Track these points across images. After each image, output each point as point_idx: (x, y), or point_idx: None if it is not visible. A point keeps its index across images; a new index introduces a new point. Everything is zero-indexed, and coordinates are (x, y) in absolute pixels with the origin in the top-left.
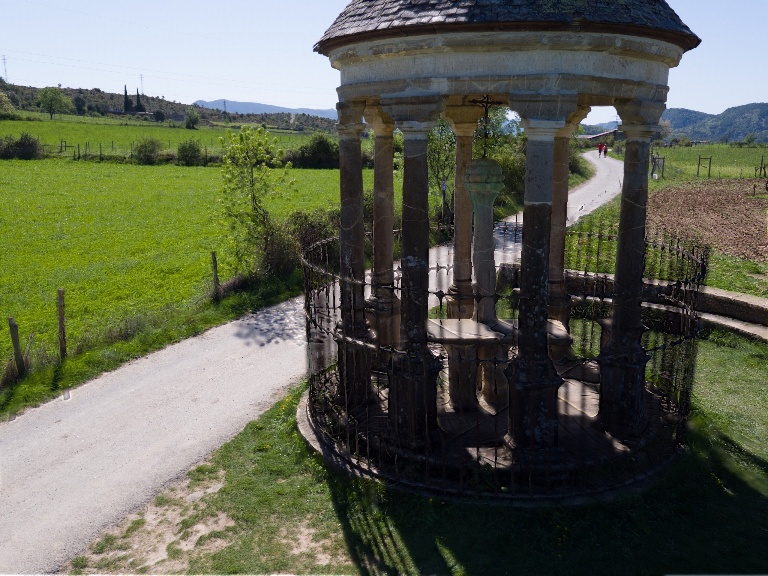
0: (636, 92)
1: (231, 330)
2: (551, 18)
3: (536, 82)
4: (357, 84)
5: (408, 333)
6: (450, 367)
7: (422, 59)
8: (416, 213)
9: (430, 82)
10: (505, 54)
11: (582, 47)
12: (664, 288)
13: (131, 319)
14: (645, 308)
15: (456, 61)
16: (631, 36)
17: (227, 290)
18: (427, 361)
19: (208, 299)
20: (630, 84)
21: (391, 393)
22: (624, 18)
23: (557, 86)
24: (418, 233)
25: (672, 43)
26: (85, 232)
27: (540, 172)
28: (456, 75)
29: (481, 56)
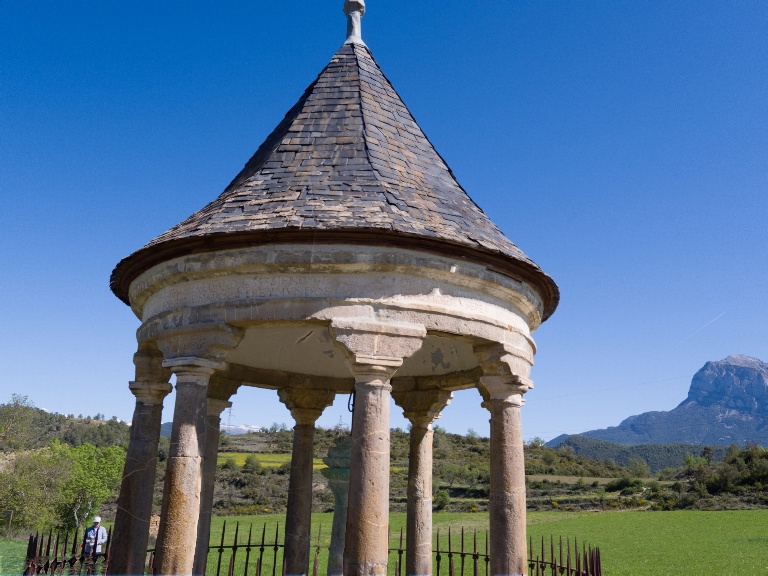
0: None
1: None
2: None
3: None
4: None
5: None
6: None
7: None
8: None
9: None
10: None
11: None
12: None
13: None
14: None
15: None
16: None
17: None
18: None
19: None
20: None
21: None
22: None
23: None
24: None
25: None
26: None
27: None
28: None
29: None
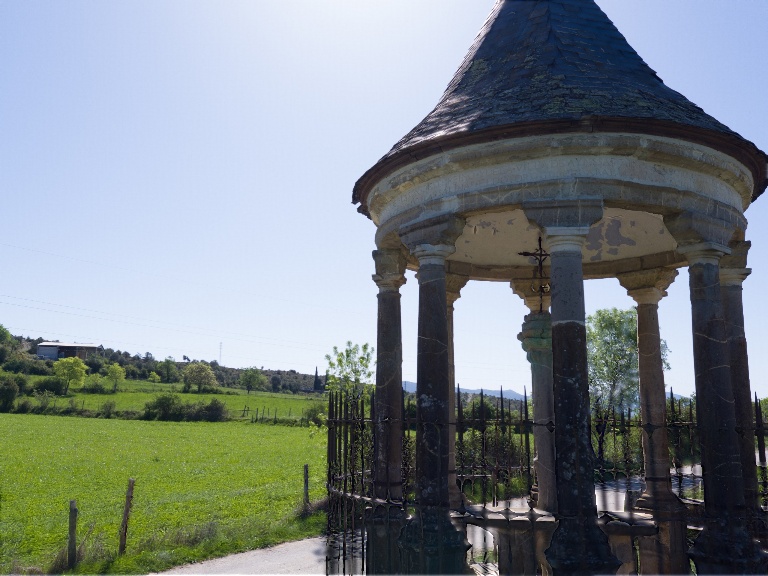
0: (683, 203)
1: (303, 545)
2: (554, 117)
3: (551, 188)
4: (383, 224)
5: (421, 492)
6: (499, 563)
7: (435, 183)
8: (430, 344)
9: (441, 202)
10: (515, 164)
11: (600, 150)
12: None
13: (204, 525)
14: None
15: (466, 178)
16: (659, 137)
17: (316, 509)
18: (445, 531)
19: (293, 516)
20: (672, 192)
21: (402, 575)
22: (643, 114)
23: (576, 191)
24: (433, 367)
25: (722, 152)
26: (223, 469)
27: (564, 286)
28: (466, 191)
29: (490, 169)
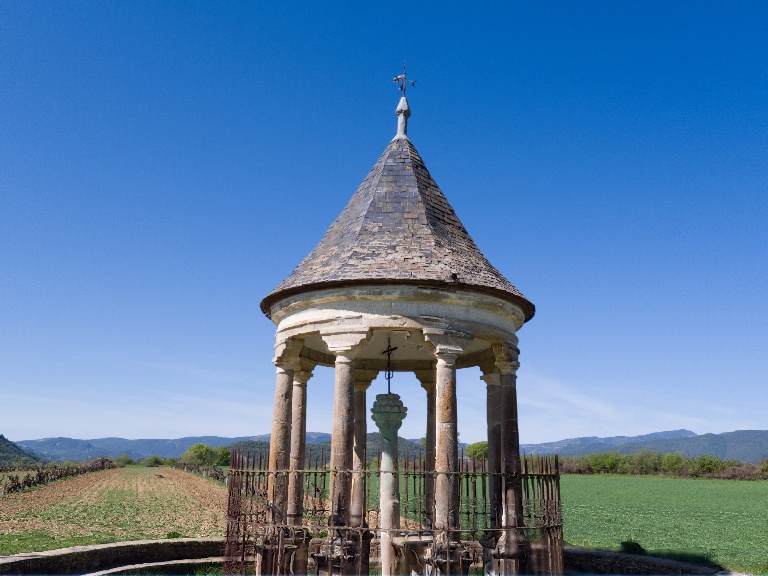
0: None
1: None
2: None
3: None
4: None
5: None
6: None
7: None
8: None
9: None
10: None
11: None
12: (133, 547)
13: None
14: (142, 569)
15: None
16: None
17: None
18: None
19: None
20: None
21: None
22: None
23: None
24: None
25: None
26: None
27: None
28: None
29: None
